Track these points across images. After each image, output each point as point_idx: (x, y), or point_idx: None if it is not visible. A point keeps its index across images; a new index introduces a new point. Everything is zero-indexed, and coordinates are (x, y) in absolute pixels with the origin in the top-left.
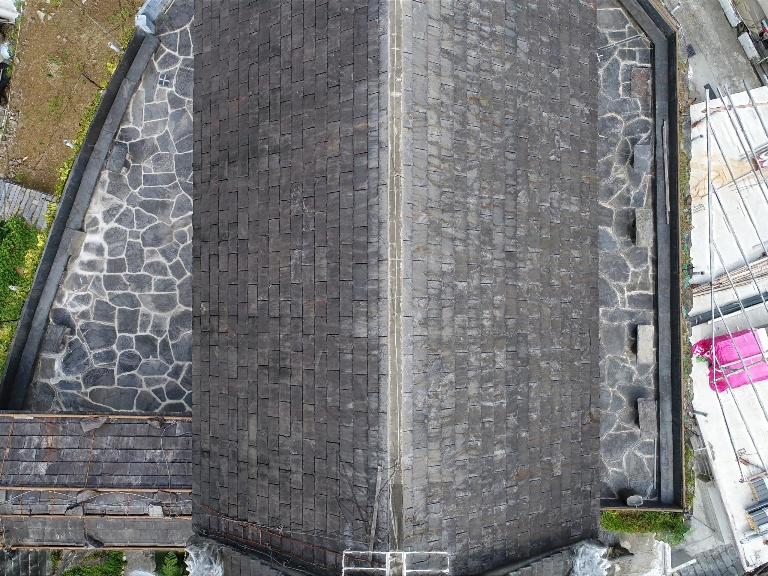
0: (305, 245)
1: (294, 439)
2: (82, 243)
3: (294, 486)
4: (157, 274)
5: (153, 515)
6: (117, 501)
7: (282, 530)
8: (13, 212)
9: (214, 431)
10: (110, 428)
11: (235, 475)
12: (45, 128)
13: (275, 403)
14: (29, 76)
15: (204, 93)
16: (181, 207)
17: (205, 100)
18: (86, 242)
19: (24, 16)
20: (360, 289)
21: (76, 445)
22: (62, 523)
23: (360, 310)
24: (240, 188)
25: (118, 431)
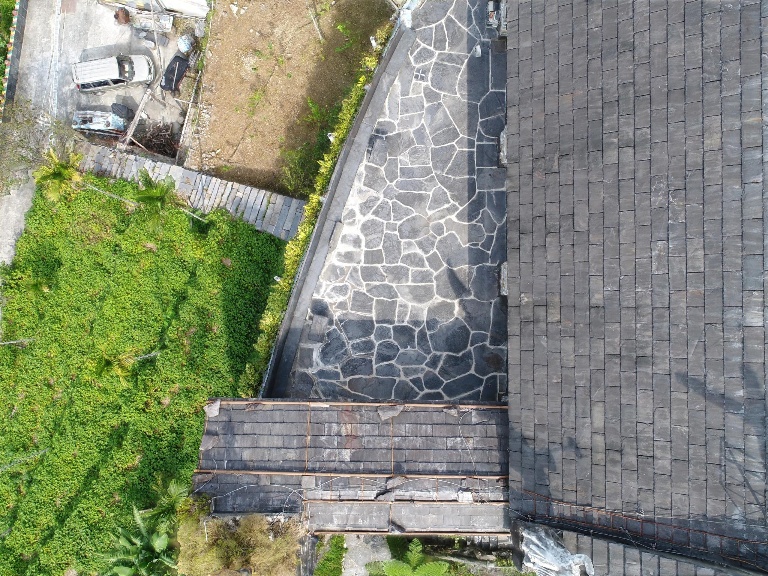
0: (673, 237)
1: (659, 426)
2: (339, 235)
3: (659, 472)
4: (414, 266)
5: (463, 501)
6: (426, 487)
7: (644, 514)
8: (214, 204)
9: (541, 419)
10: (407, 416)
11: (572, 461)
12: (238, 121)
13: (631, 391)
14: (221, 69)
15: (522, 87)
16: (437, 200)
17: (524, 94)
18: (343, 234)
19: (216, 10)
20: (753, 279)
21: (376, 433)
22: (368, 509)
23: (753, 300)
24: (577, 181)
25: (415, 419)
